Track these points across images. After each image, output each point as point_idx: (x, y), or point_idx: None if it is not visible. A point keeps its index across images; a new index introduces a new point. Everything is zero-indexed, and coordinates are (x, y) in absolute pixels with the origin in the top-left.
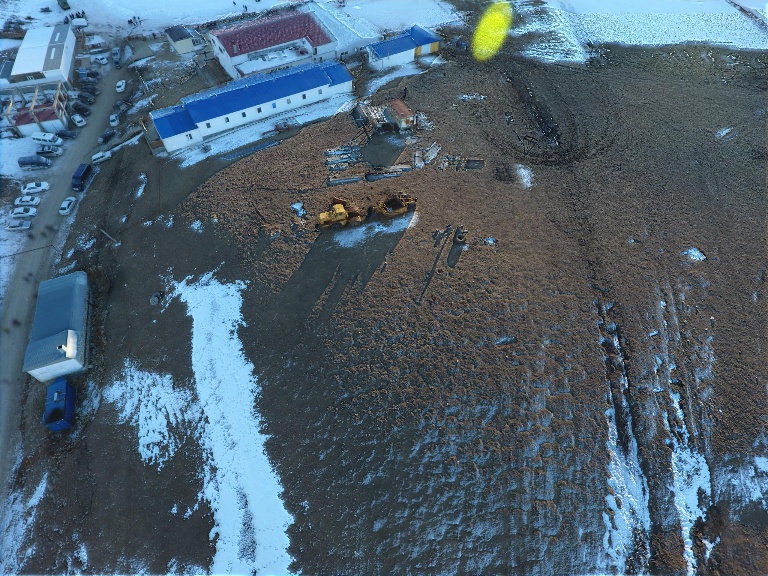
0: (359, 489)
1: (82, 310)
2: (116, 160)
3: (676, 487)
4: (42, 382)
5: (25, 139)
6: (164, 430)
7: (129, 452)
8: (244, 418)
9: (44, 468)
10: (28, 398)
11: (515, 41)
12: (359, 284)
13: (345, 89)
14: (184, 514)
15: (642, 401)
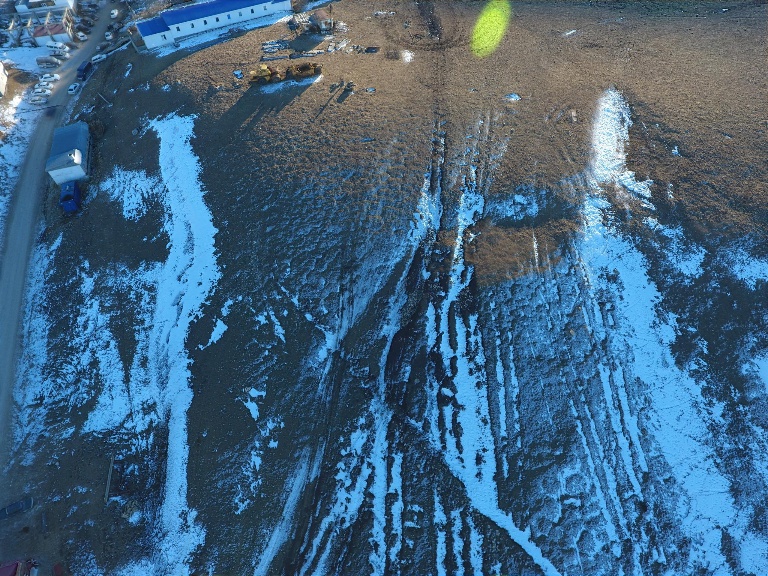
0: (260, 213)
1: (85, 143)
2: (110, 60)
3: (461, 210)
4: (58, 185)
5: (41, 48)
6: (140, 201)
7: (117, 214)
8: (191, 185)
9: (60, 230)
10: (48, 197)
11: None
12: (274, 112)
13: (285, 8)
14: (151, 240)
15: (450, 169)
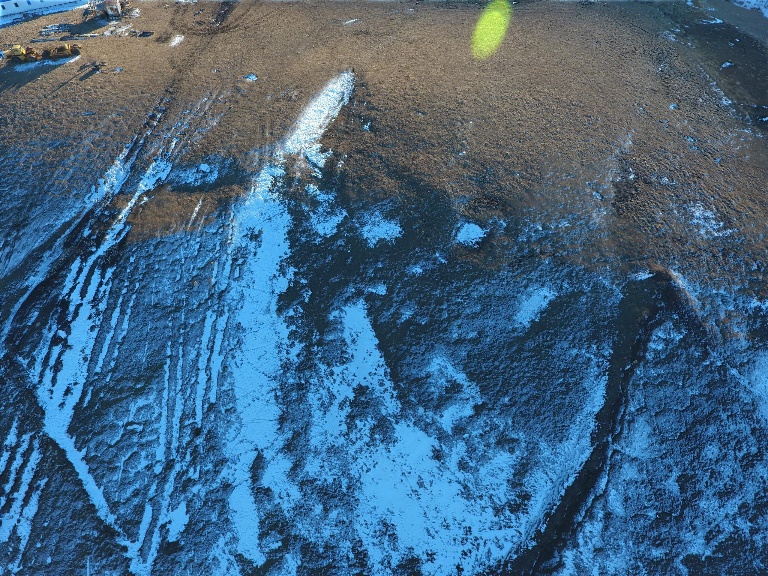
0: None
1: None
2: None
3: (145, 177)
4: None
5: None
6: None
7: None
8: None
9: None
10: None
11: None
12: (14, 88)
13: None
14: None
15: (152, 140)
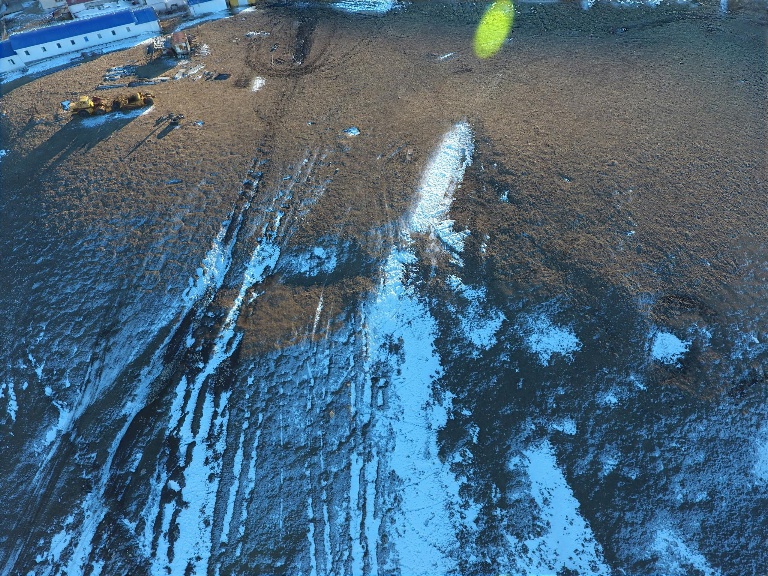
0: (32, 266)
1: None
2: None
3: (251, 265)
4: None
5: None
6: None
7: None
8: None
9: None
10: None
11: None
12: (84, 149)
13: (153, 28)
14: None
15: (253, 216)
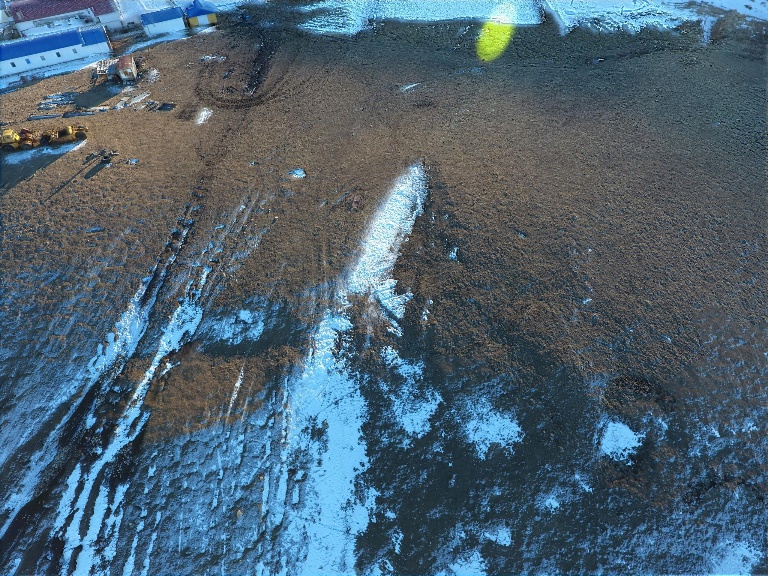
0: None
1: None
2: None
3: (168, 329)
4: None
5: None
6: None
7: None
8: None
9: None
10: None
11: (299, 15)
12: (3, 190)
13: (102, 50)
14: None
15: (177, 272)
